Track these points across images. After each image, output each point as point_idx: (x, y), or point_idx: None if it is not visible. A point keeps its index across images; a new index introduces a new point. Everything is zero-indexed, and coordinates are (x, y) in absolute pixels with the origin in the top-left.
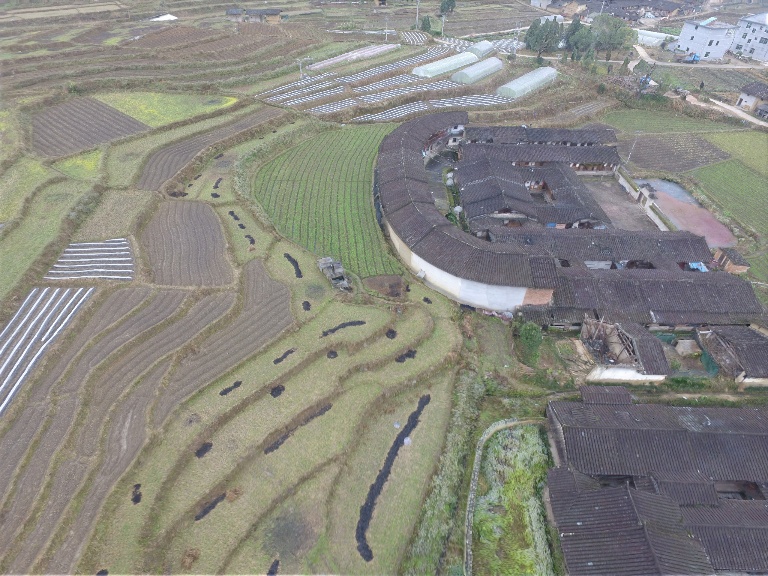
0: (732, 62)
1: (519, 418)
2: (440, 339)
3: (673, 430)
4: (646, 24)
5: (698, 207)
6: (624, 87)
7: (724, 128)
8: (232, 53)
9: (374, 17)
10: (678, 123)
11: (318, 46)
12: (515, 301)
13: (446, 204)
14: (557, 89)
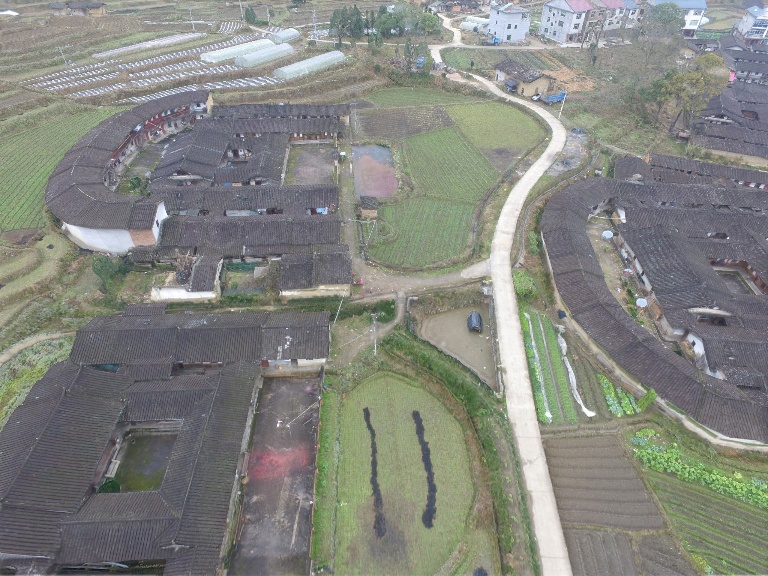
0: (532, 44)
1: (63, 330)
2: (34, 275)
3: (166, 328)
4: (485, 11)
5: (388, 166)
6: (398, 67)
7: (470, 100)
8: (21, 44)
9: (225, 9)
10: (433, 97)
11: (118, 36)
12: (127, 243)
13: (147, 171)
14: (336, 70)
